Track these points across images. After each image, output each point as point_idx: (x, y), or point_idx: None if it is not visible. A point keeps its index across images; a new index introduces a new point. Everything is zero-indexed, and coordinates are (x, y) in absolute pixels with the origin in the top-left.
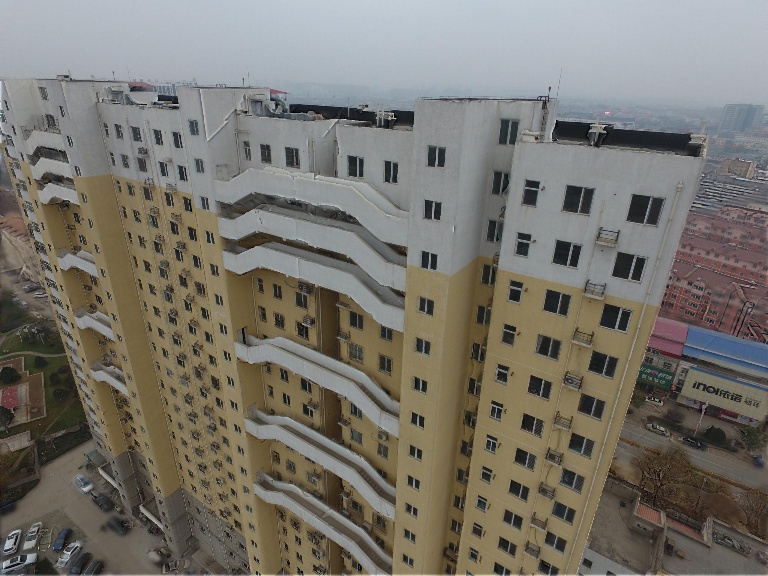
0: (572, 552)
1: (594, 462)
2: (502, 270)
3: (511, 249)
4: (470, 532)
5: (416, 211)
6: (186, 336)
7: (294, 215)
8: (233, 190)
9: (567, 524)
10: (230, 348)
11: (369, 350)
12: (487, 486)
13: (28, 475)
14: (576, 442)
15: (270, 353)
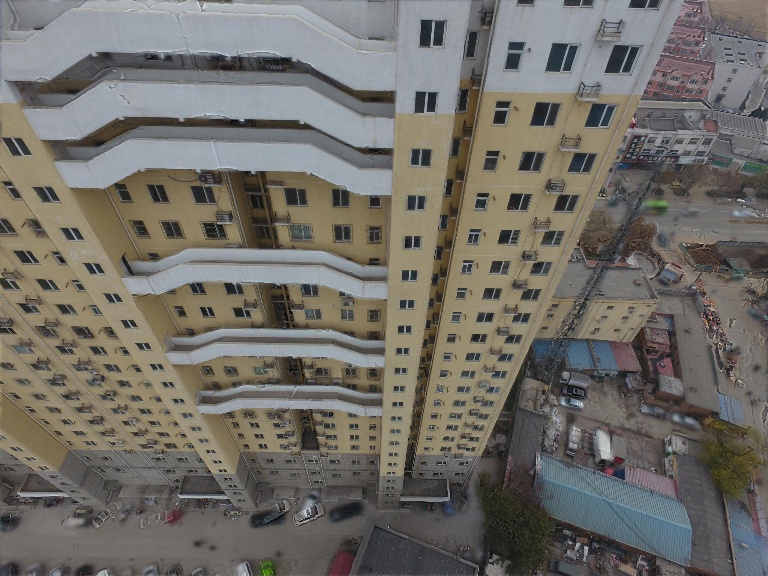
0: (535, 319)
1: (563, 247)
2: (489, 92)
3: (501, 65)
4: (445, 342)
5: (408, 38)
6: (1, 296)
7: (174, 77)
8: (44, 55)
9: (533, 302)
10: (116, 288)
11: (319, 225)
12: (463, 302)
13: None
14: (547, 237)
15: (190, 273)
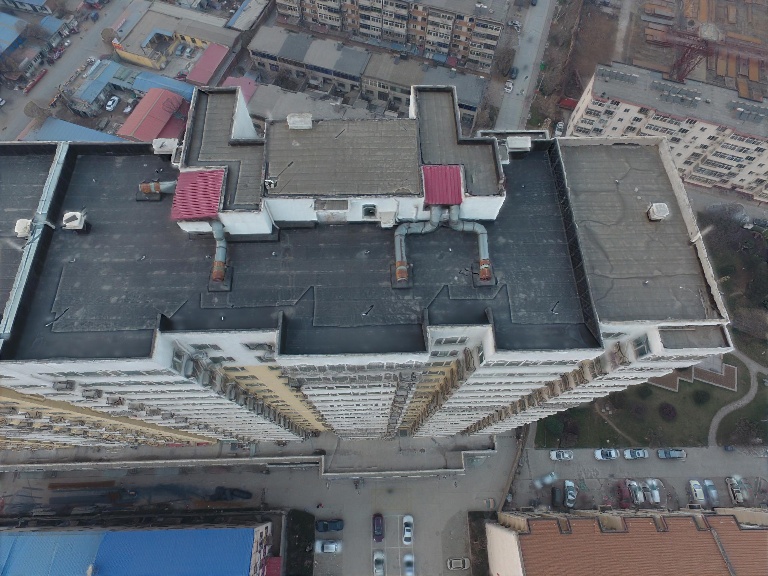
0: None
1: None
2: None
3: None
4: None
5: None
6: None
7: None
8: None
9: None
10: None
11: None
12: None
13: None
14: None
15: None
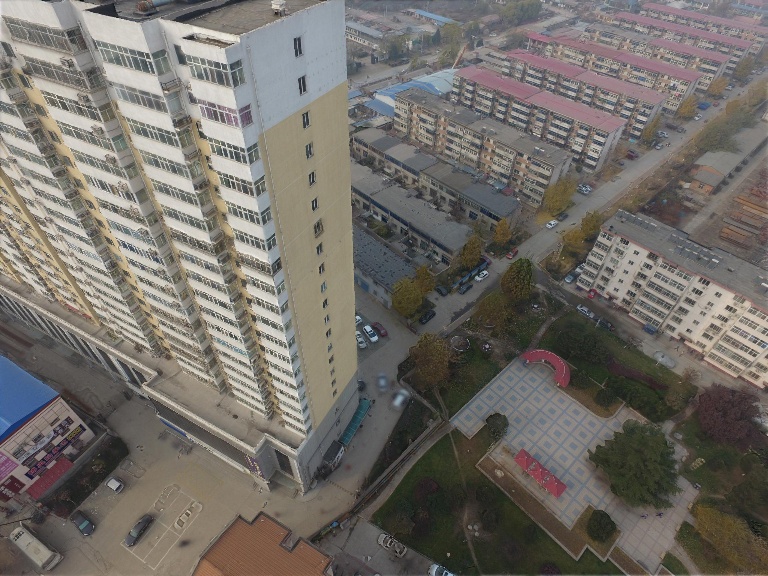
0: None
1: None
2: None
3: None
4: None
5: None
6: None
7: None
8: None
9: None
10: None
11: None
12: None
13: (415, 387)
14: None
15: None
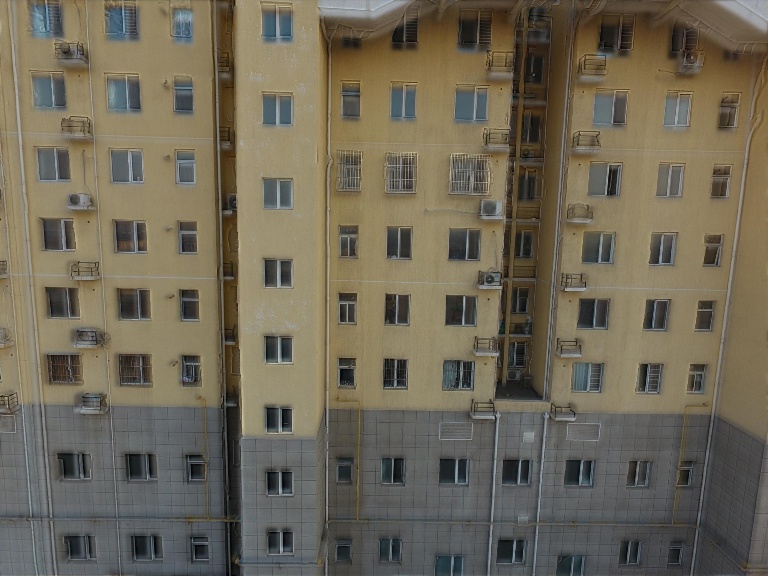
0: None
1: None
2: None
3: None
4: None
5: None
6: None
7: None
8: None
9: None
10: None
11: None
12: None
13: None
14: None
15: None
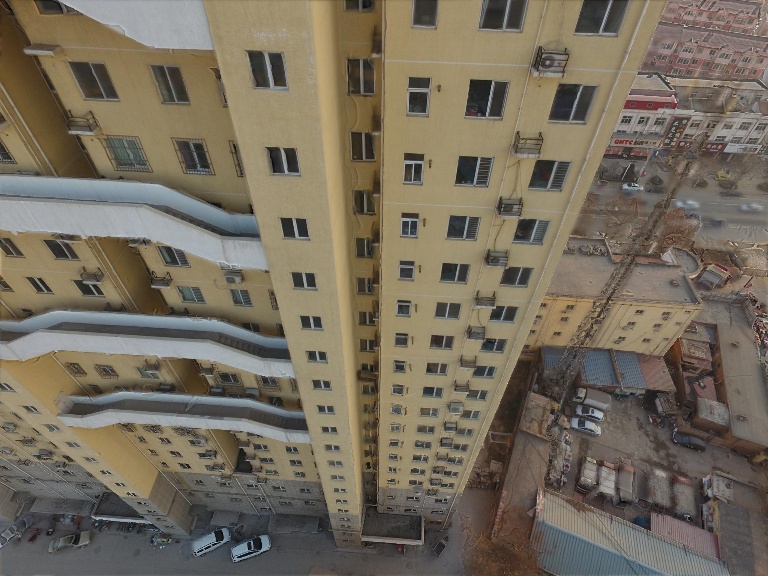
0: (525, 316)
1: (567, 193)
2: None
3: None
4: (392, 345)
5: None
6: None
7: None
8: None
9: (520, 288)
10: None
11: (150, 139)
12: (410, 284)
13: None
14: (540, 174)
15: None
